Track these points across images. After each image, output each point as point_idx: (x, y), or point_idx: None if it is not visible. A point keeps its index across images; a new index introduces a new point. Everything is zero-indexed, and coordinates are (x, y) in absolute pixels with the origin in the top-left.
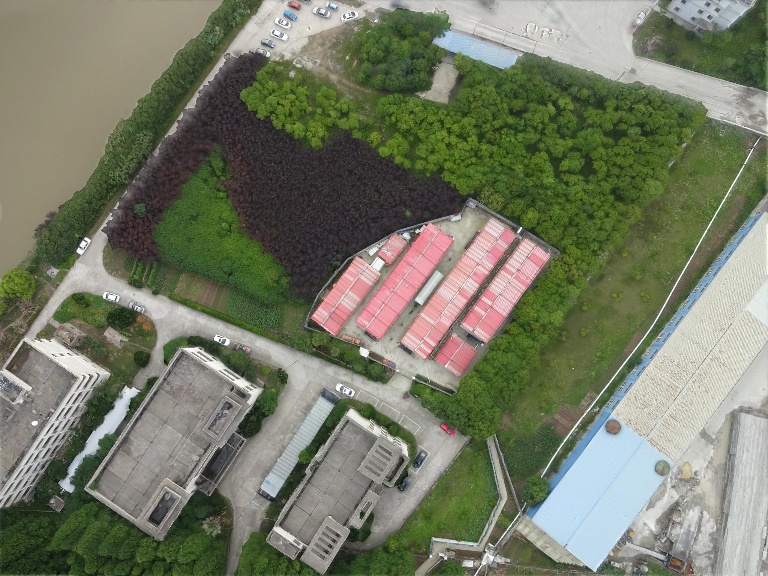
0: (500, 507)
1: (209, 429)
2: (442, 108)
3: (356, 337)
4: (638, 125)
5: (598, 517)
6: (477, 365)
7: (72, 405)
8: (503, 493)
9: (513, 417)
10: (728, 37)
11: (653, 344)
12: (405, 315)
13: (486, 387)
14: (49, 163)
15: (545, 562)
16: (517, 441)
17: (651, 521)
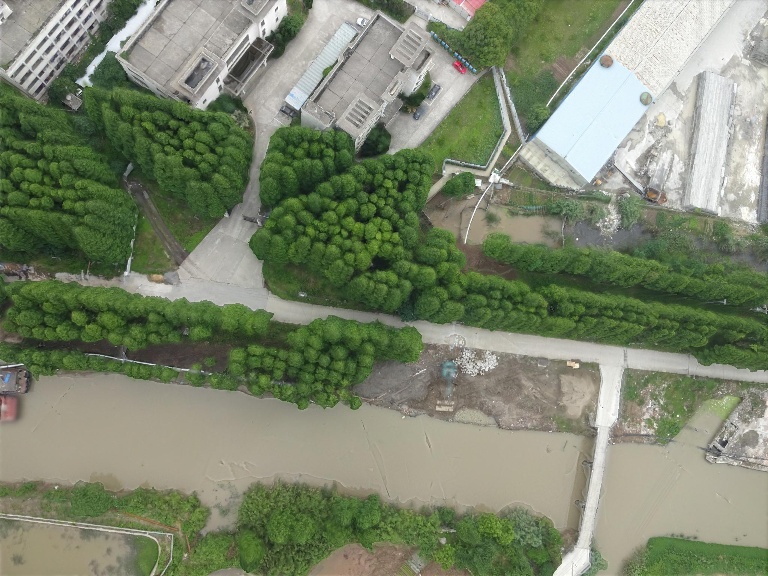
0: (505, 139)
1: None
2: None
3: None
4: None
5: (593, 135)
6: None
7: None
8: (508, 127)
9: (517, 62)
10: None
11: None
12: None
13: (500, 10)
14: None
15: (543, 188)
16: (521, 81)
17: (632, 160)
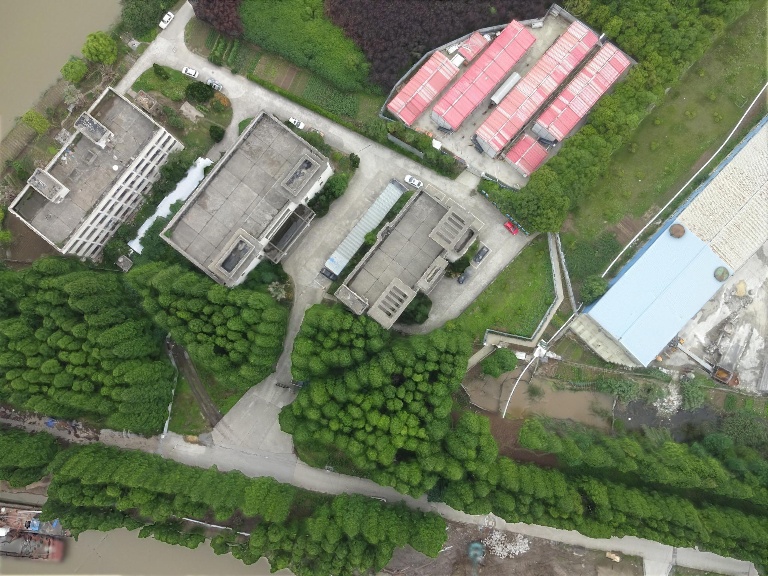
0: (556, 307)
1: (286, 185)
2: None
3: (429, 132)
4: None
5: (654, 315)
6: (549, 160)
7: (150, 162)
8: (560, 294)
9: (576, 222)
10: None
11: (721, 163)
12: (479, 115)
13: (557, 178)
14: None
15: (595, 362)
16: (578, 244)
17: (701, 334)
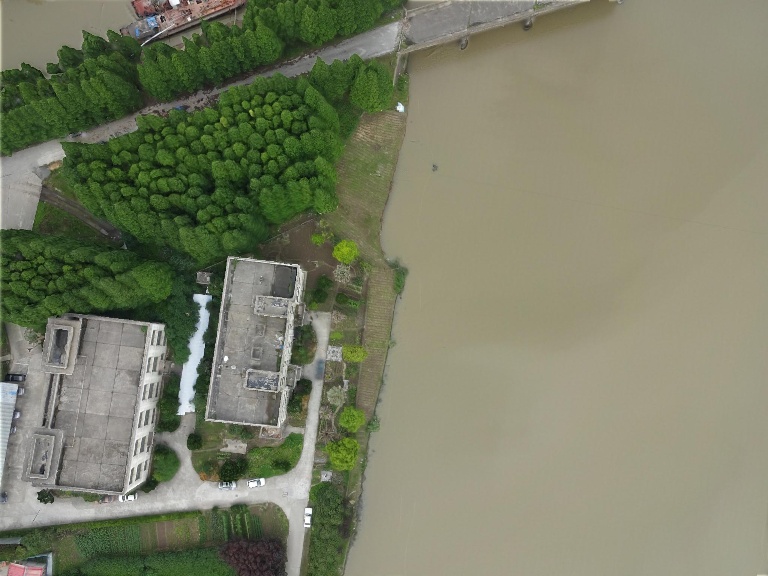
0: None
1: None
2: None
3: None
4: None
5: None
6: None
7: None
8: None
9: None
10: None
11: None
12: None
13: None
14: (392, 575)
15: None
16: None
17: None
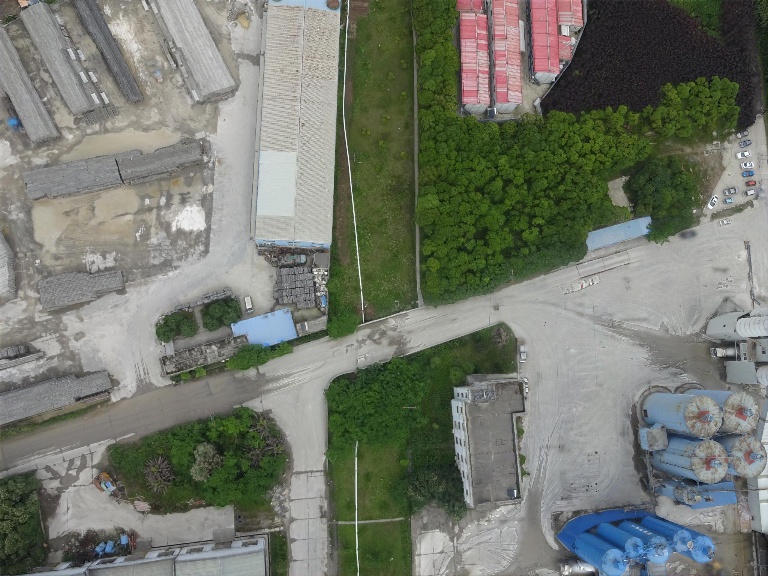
0: None
1: None
2: (610, 168)
3: None
4: (470, 252)
5: None
6: None
7: None
8: None
9: None
10: (455, 375)
11: None
12: (519, 12)
13: None
14: None
15: None
16: None
17: None
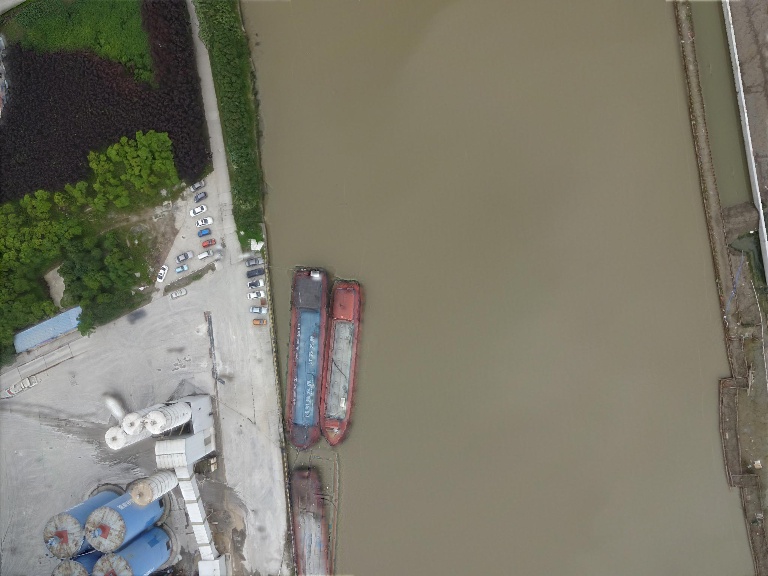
0: None
1: None
2: (30, 263)
3: None
4: None
5: None
6: None
7: None
8: None
9: None
10: None
11: None
12: None
13: None
14: None
15: None
16: None
17: None
